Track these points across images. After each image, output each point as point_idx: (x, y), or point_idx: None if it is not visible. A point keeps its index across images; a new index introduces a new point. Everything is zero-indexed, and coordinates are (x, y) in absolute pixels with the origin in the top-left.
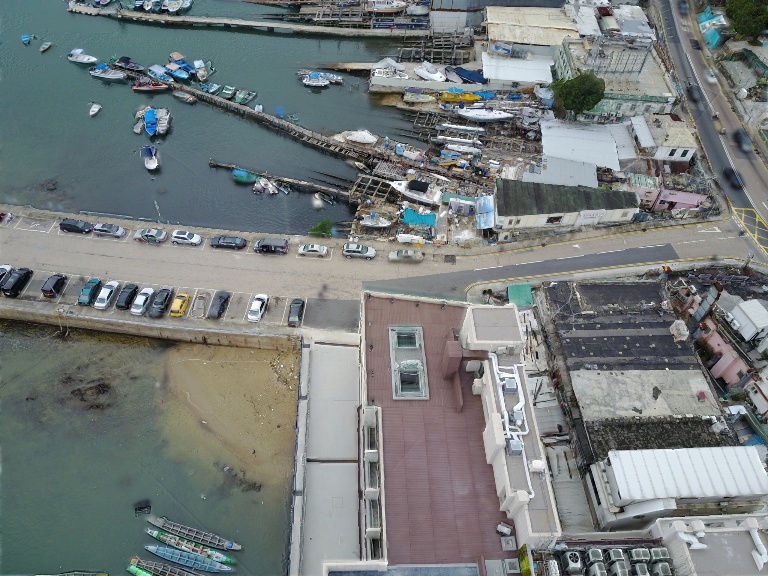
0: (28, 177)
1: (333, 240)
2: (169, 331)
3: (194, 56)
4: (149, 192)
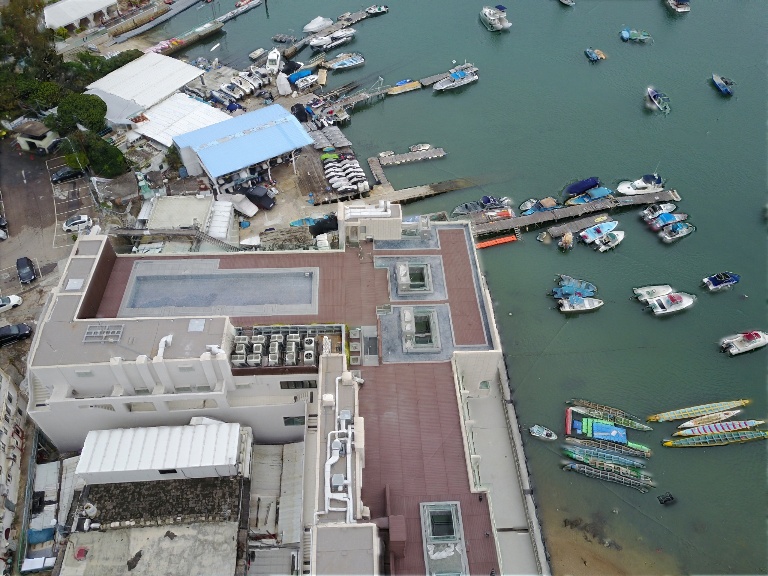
0: None
1: None
2: None
3: None
4: None
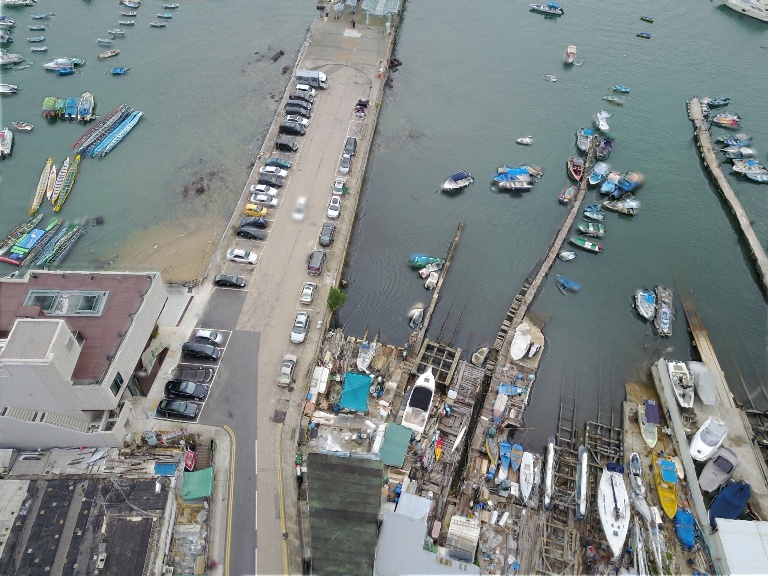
0: (425, 122)
1: (323, 309)
2: None
3: (640, 191)
4: (417, 190)
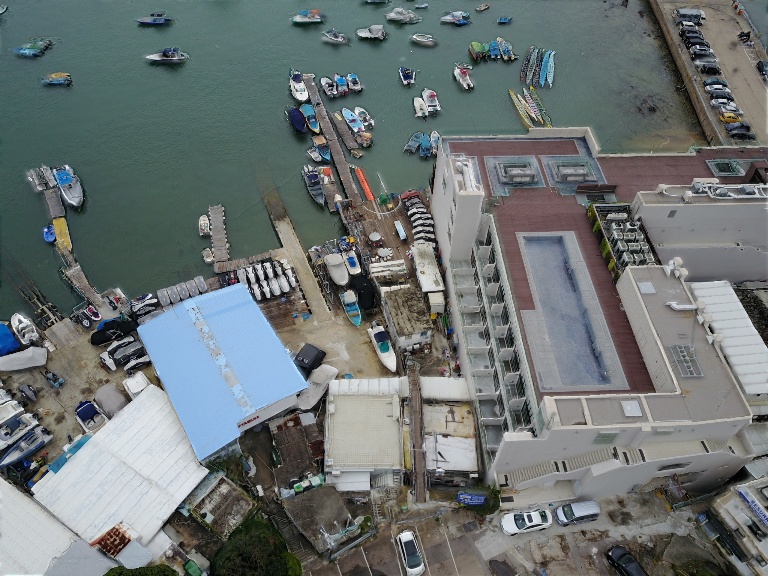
0: None
1: None
2: (708, 121)
3: None
4: None
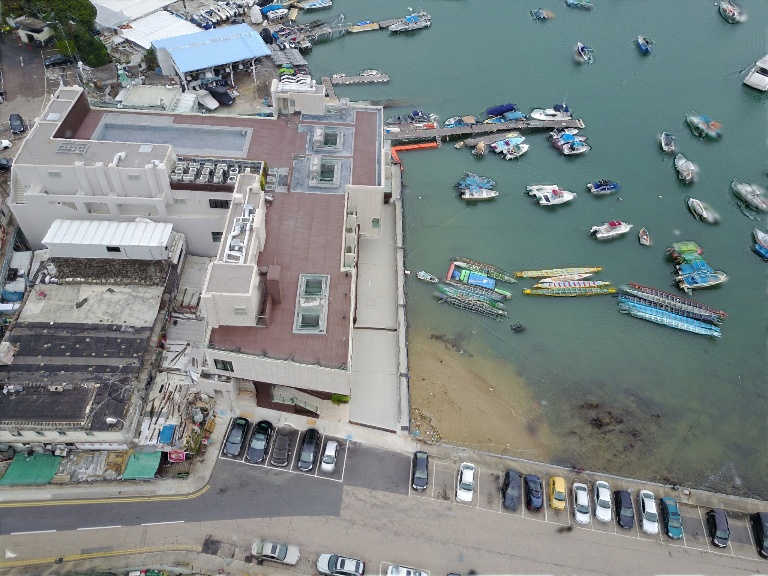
0: None
1: None
2: None
3: None
4: None
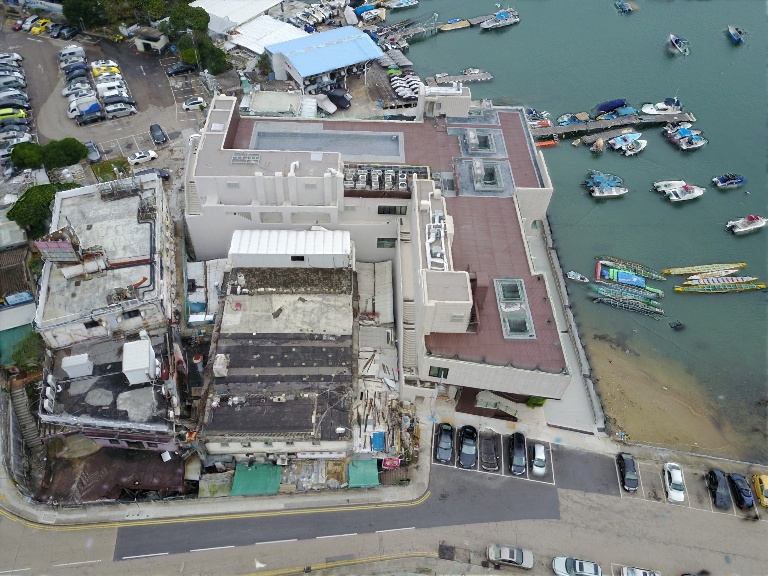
0: None
1: None
2: None
3: None
4: None
